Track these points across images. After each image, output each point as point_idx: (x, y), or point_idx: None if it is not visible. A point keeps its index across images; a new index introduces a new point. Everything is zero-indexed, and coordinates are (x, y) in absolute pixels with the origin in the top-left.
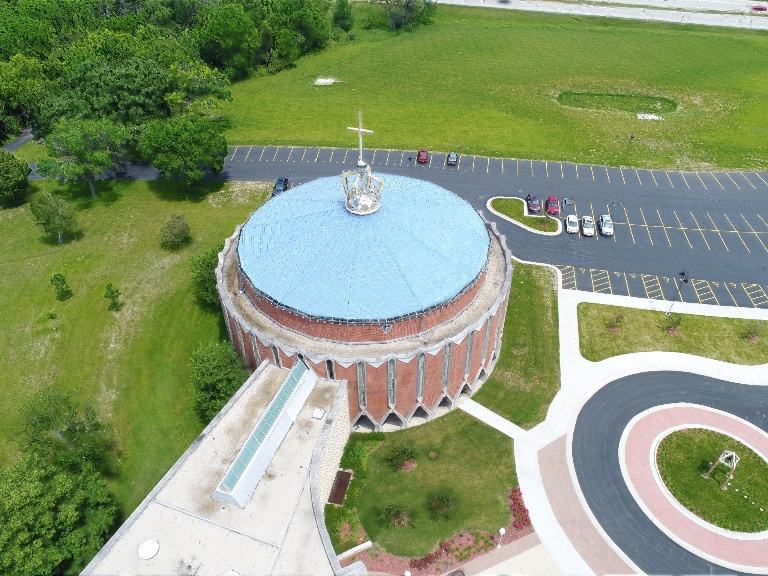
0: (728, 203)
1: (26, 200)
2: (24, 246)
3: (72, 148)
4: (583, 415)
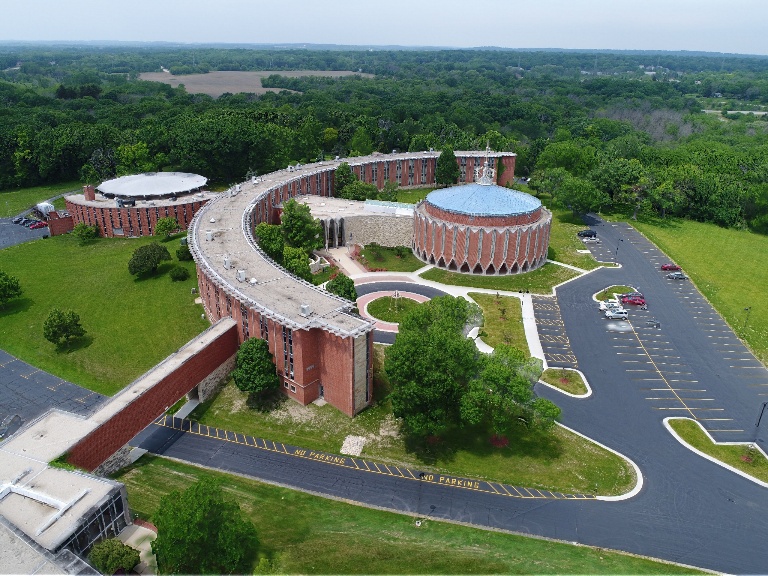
0: (718, 381)
1: (539, 198)
2: None
3: None
4: (429, 287)
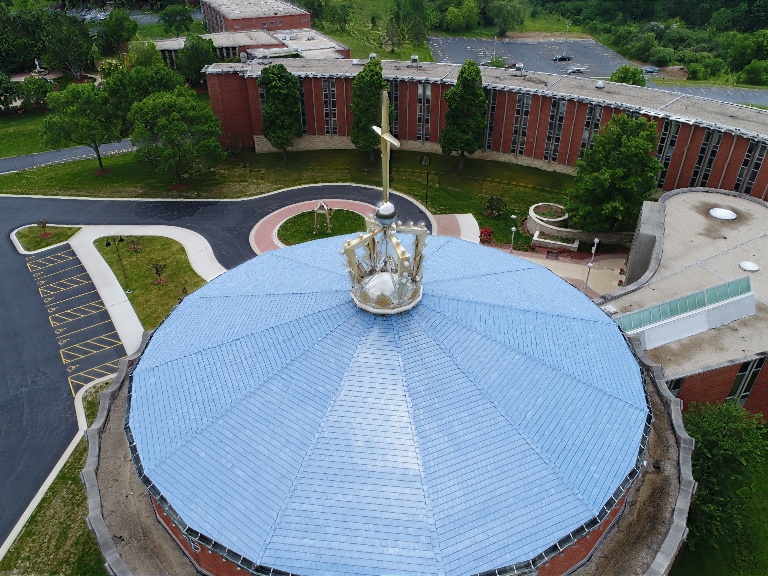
0: None
1: None
2: None
3: None
4: None
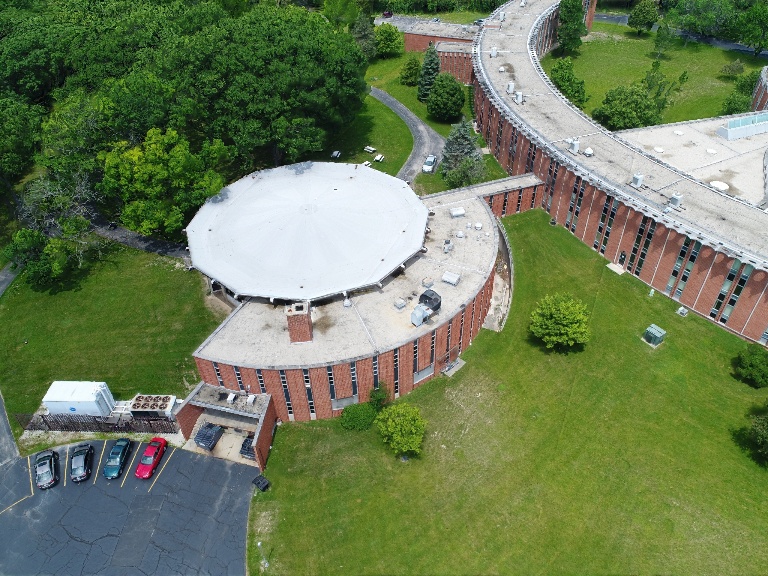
0: None
1: (643, 38)
2: (636, 54)
3: (697, 6)
4: None
